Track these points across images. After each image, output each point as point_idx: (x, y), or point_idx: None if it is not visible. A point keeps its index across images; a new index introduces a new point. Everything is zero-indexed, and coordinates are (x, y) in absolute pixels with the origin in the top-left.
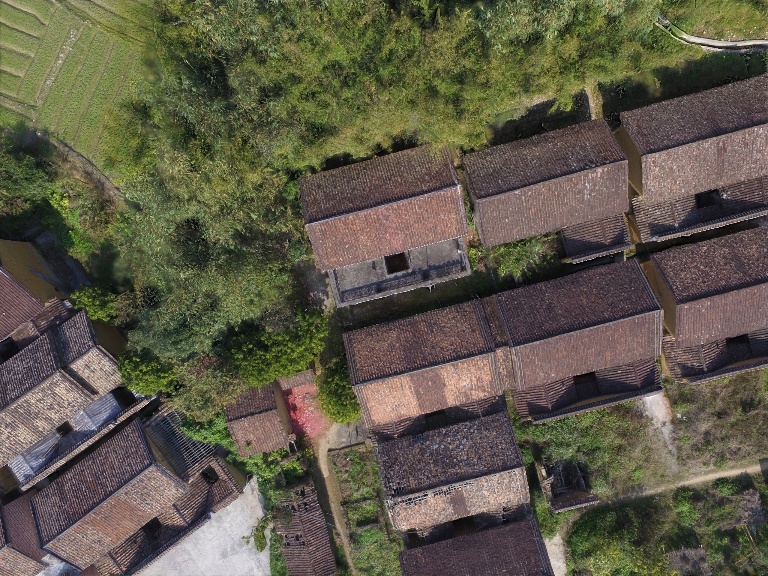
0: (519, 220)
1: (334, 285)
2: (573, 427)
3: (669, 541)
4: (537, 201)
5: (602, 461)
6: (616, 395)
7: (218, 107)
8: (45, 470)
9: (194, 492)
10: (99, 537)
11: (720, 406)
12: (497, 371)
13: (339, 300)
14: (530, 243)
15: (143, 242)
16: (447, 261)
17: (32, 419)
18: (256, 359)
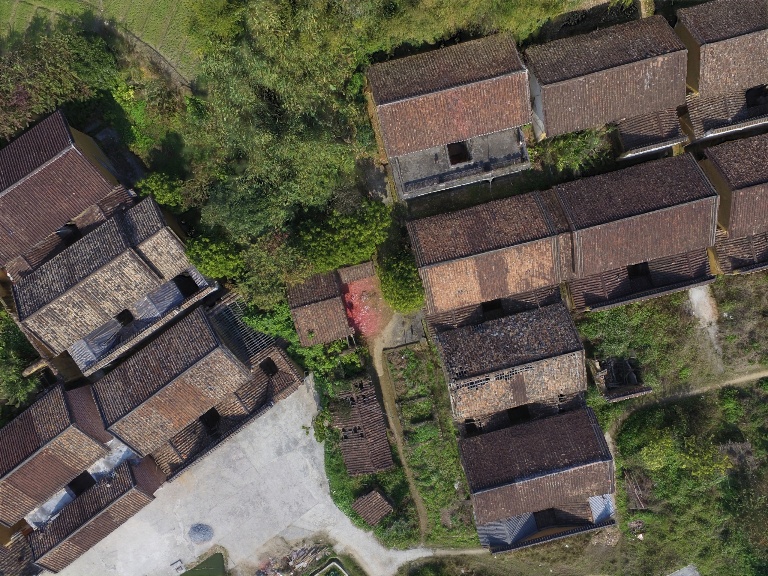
0: (581, 109)
1: (397, 176)
2: (624, 324)
3: (715, 438)
4: (599, 90)
5: (652, 357)
6: (670, 286)
7: None
8: (108, 355)
9: (254, 383)
10: (162, 422)
11: (765, 304)
12: (559, 256)
13: (403, 189)
14: (590, 134)
15: (207, 135)
16: (508, 154)
17: (99, 300)
18: (325, 240)
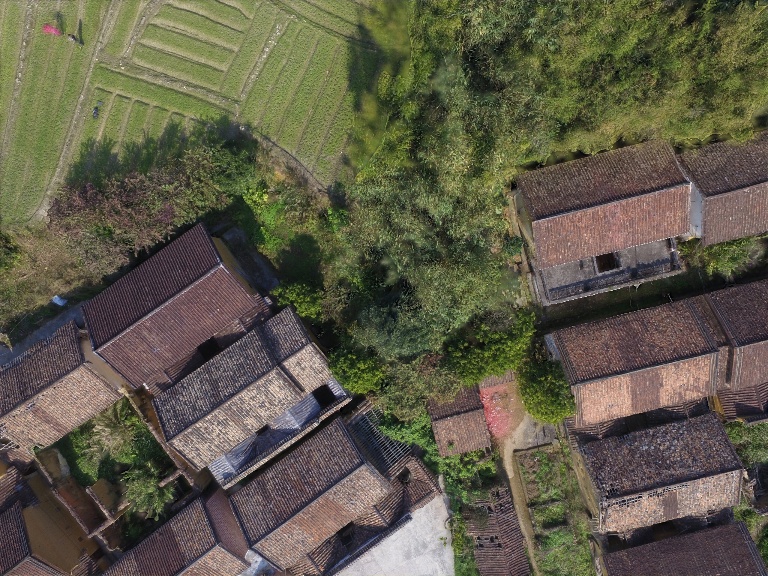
0: (742, 218)
1: (541, 283)
2: None
3: None
4: (763, 199)
5: None
6: None
7: (488, 101)
8: (248, 469)
9: (390, 492)
10: (303, 537)
11: None
12: (717, 371)
13: (549, 298)
14: (748, 242)
15: (340, 239)
16: (656, 260)
17: (243, 417)
18: (475, 357)
